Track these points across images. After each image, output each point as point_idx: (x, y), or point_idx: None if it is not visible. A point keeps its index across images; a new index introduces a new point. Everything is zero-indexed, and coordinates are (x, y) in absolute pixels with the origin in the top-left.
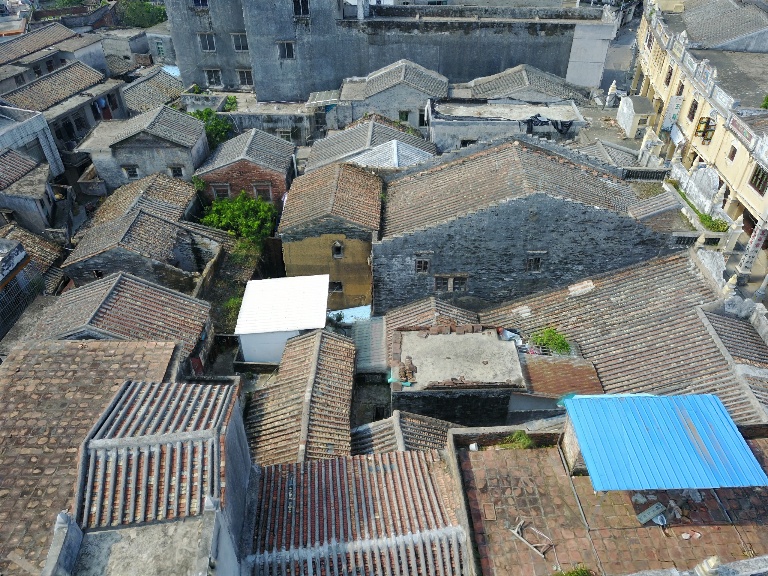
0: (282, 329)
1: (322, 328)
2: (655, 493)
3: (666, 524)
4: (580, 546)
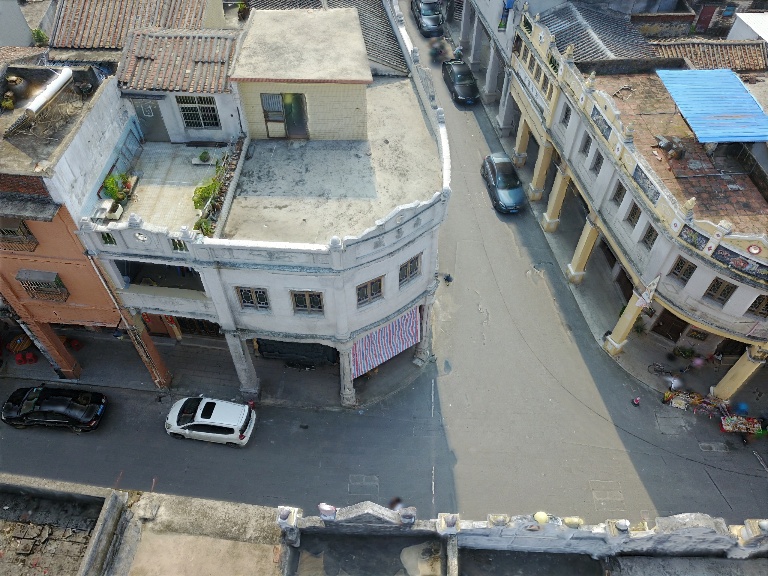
0: (754, 28)
1: (767, 42)
2: (685, 148)
3: (661, 147)
4: (627, 110)
